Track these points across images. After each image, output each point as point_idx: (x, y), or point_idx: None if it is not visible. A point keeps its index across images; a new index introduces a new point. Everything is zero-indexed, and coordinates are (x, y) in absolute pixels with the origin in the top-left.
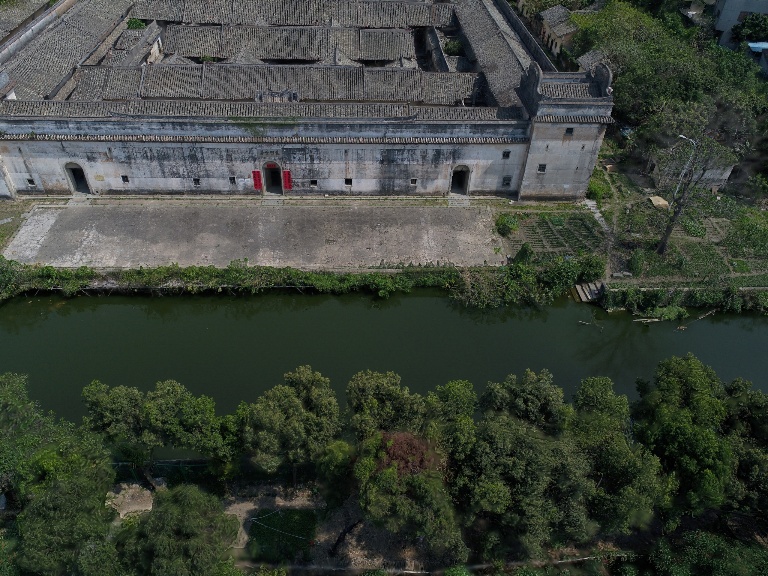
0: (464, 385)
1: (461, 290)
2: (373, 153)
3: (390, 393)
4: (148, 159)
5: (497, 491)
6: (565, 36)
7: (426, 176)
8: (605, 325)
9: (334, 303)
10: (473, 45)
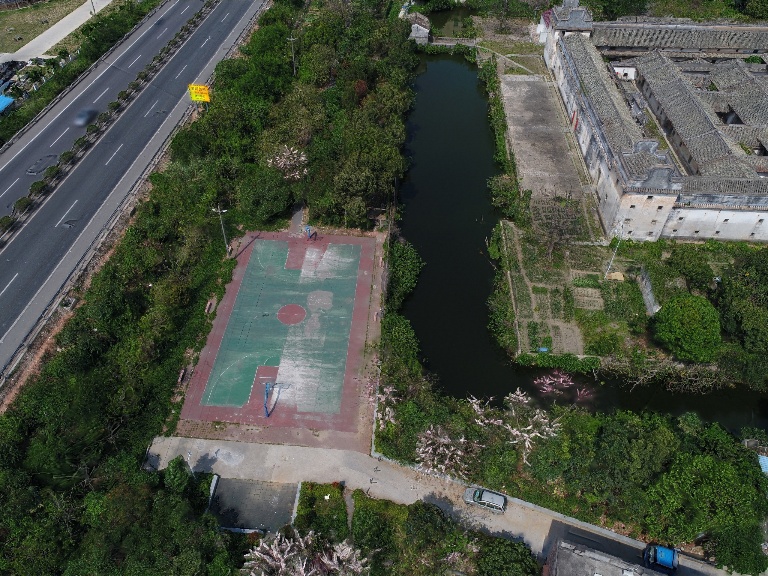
0: (403, 126)
1: None
2: None
3: None
4: None
5: None
6: None
7: None
8: None
9: None
10: None
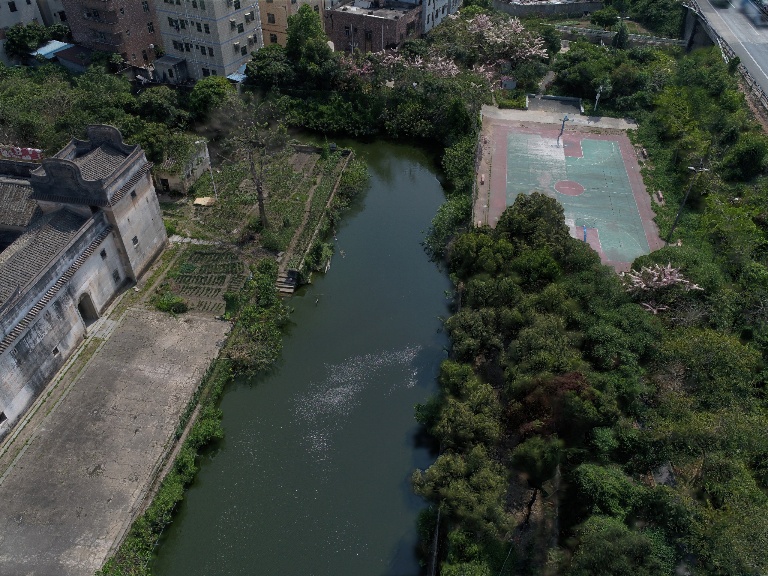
0: (446, 364)
1: (244, 368)
2: (5, 364)
3: (480, 399)
4: None
5: (566, 360)
6: None
7: (61, 335)
8: (306, 295)
9: (193, 494)
10: None
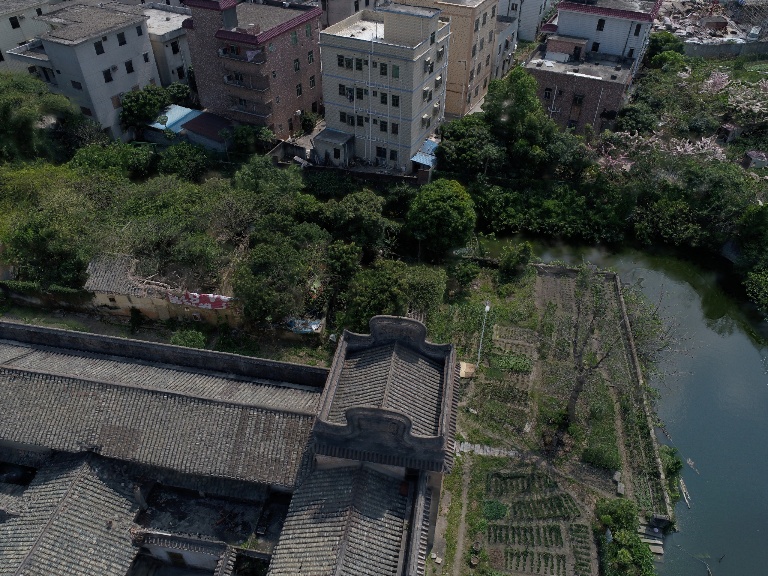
0: None
1: None
2: None
3: None
4: None
5: None
6: None
7: None
8: None
9: None
10: None
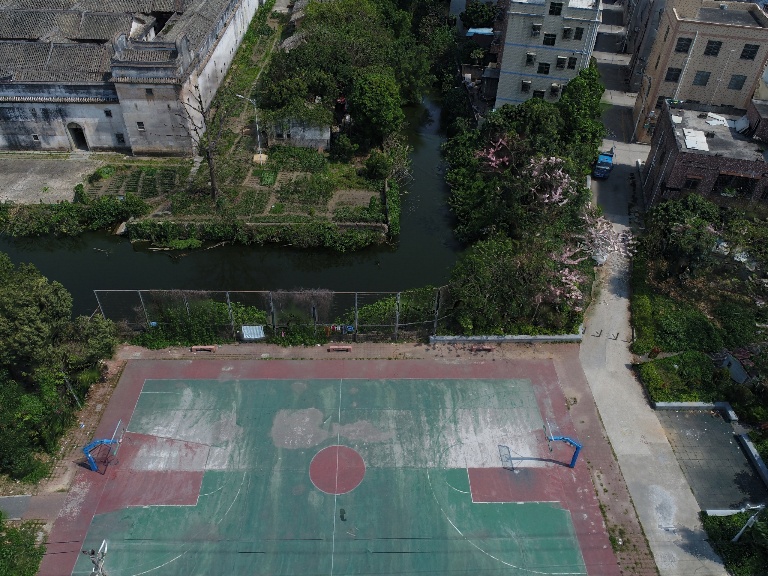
0: None
1: None
2: None
3: None
4: None
5: None
6: (297, 21)
7: (45, 133)
8: None
9: None
10: None
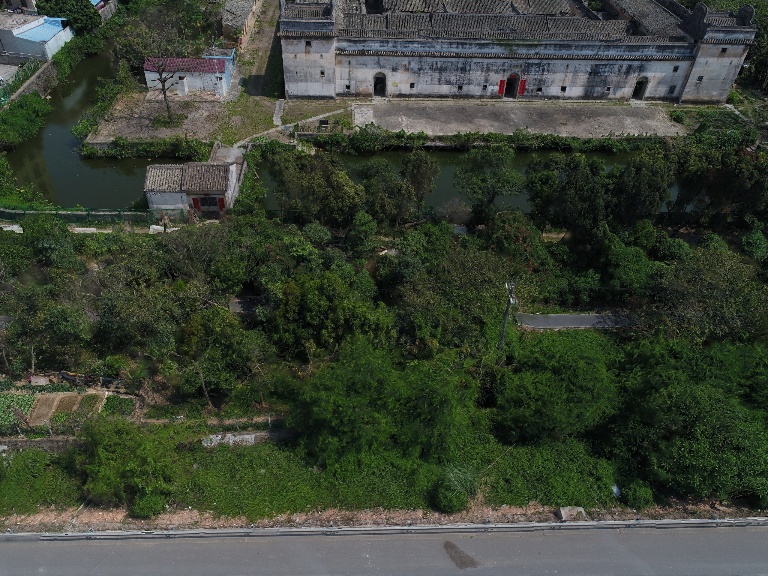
0: None
1: (664, 150)
2: (586, 67)
3: (706, 152)
4: (433, 70)
5: None
6: None
7: (618, 85)
8: None
9: None
10: (618, 2)
